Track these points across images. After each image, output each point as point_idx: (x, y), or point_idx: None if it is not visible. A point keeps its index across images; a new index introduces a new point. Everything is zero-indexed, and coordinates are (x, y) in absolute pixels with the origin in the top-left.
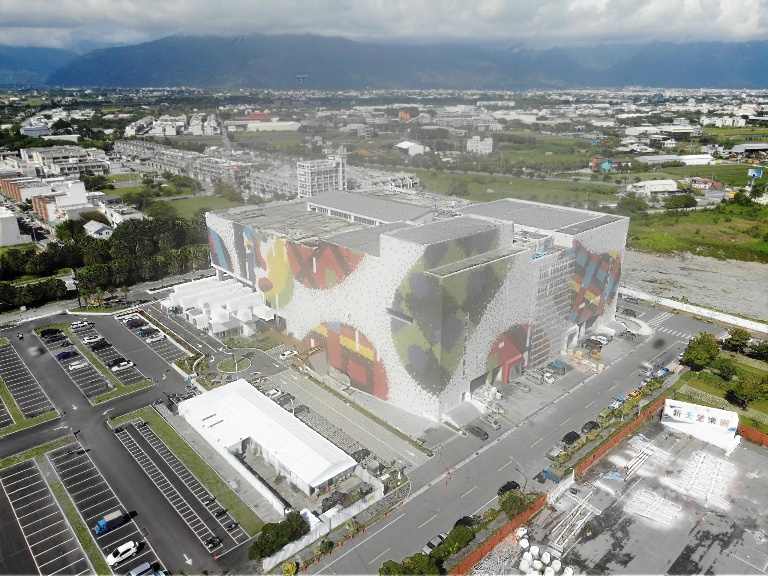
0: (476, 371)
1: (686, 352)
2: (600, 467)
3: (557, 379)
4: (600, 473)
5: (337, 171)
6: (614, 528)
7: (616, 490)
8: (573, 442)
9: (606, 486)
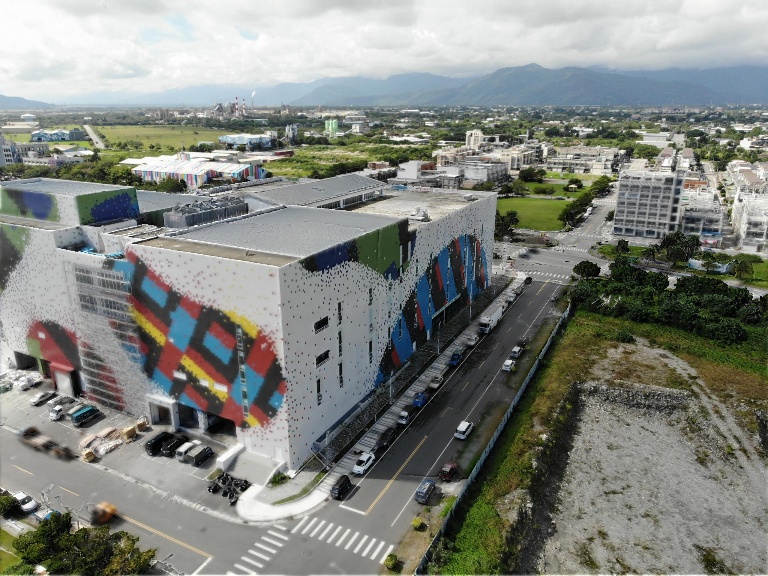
0: (18, 344)
1: None
2: None
3: (64, 423)
4: None
5: (669, 190)
6: None
7: None
8: None
9: None
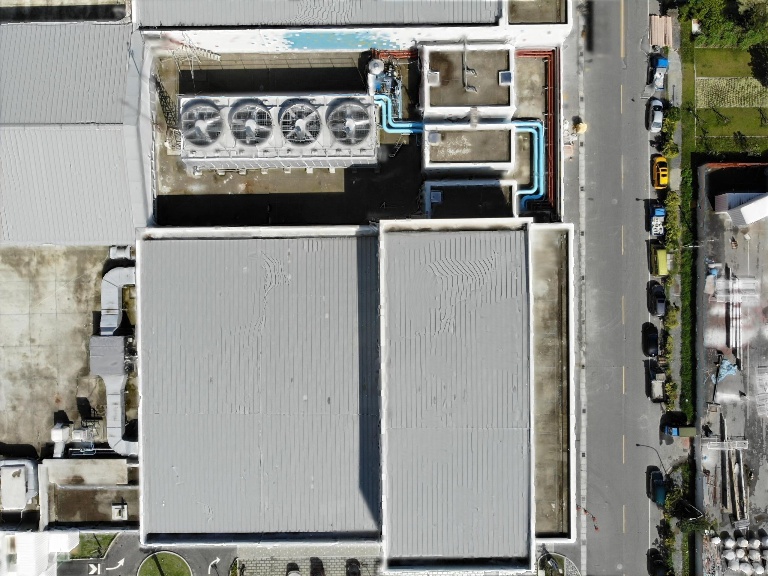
0: None
1: (687, 7)
2: (705, 366)
3: None
4: (712, 378)
5: None
6: (765, 449)
7: (739, 392)
8: (658, 347)
9: (728, 394)
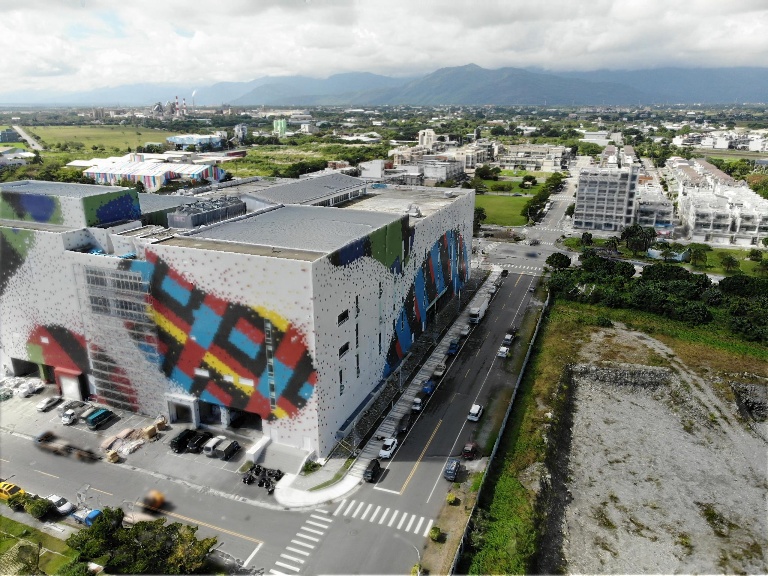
0: (16, 350)
1: None
2: None
3: (78, 427)
4: None
5: (625, 185)
6: None
7: None
8: None
9: None
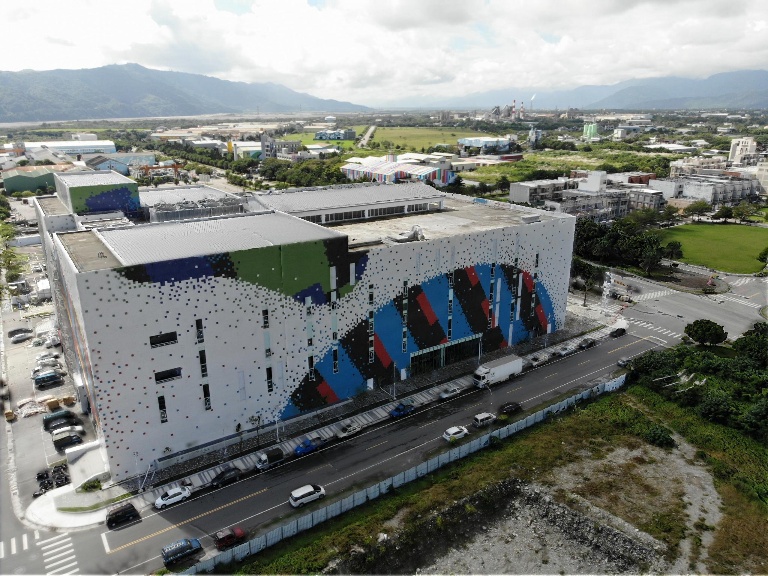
0: None
1: None
2: None
3: None
4: None
5: None
6: None
7: None
8: None
9: None
